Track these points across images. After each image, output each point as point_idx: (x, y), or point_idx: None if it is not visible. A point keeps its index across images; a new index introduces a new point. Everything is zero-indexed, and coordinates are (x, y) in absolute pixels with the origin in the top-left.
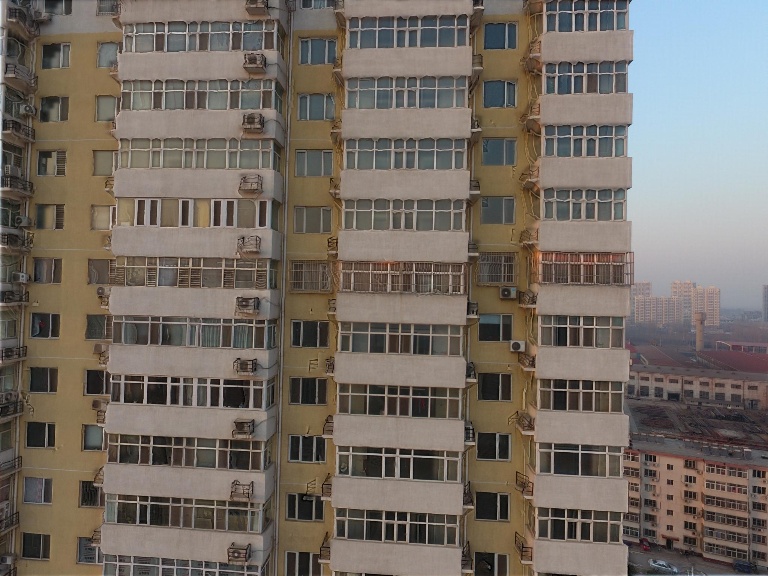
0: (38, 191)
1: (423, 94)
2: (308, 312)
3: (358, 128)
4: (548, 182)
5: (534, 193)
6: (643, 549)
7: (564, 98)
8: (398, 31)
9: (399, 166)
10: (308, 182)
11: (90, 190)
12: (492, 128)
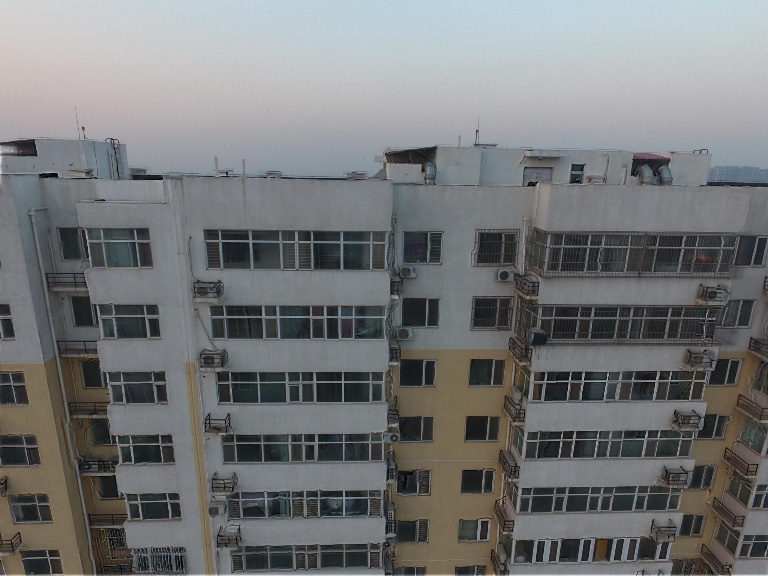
0: (400, 510)
1: None
2: None
3: None
4: None
5: None
6: None
7: None
8: None
9: None
10: (688, 495)
11: (460, 509)
12: None
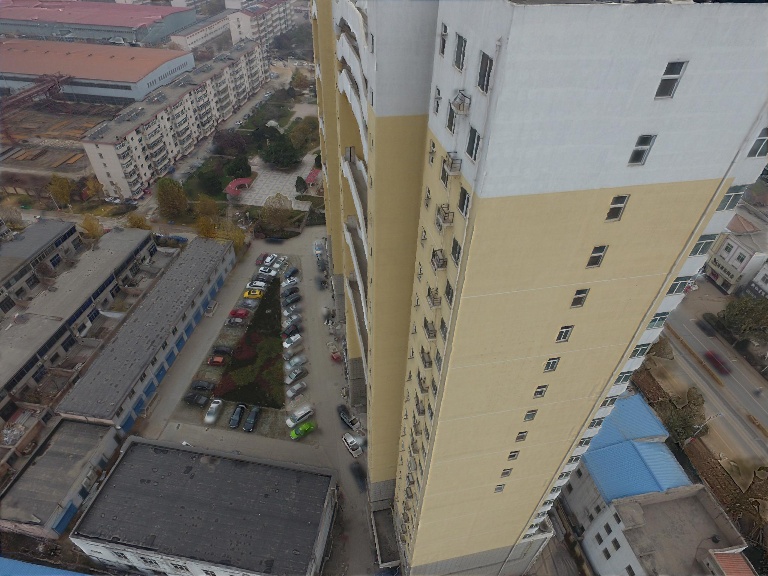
0: None
1: None
2: None
3: None
4: None
5: None
6: (149, 194)
7: None
8: None
9: None
10: None
11: None
12: None
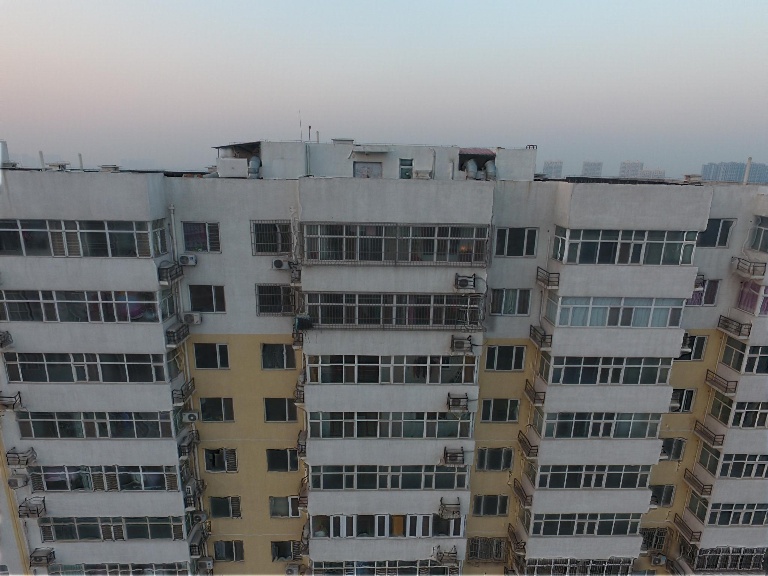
0: (210, 486)
1: (619, 425)
2: (482, 575)
3: (554, 457)
4: (718, 499)
5: (702, 502)
6: None
7: (748, 433)
8: (602, 368)
9: (587, 485)
10: (488, 476)
11: (267, 486)
12: (666, 431)
